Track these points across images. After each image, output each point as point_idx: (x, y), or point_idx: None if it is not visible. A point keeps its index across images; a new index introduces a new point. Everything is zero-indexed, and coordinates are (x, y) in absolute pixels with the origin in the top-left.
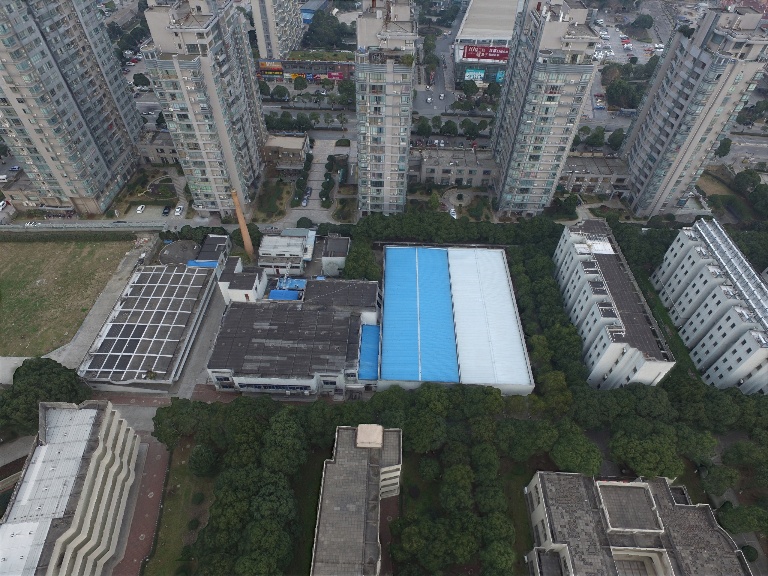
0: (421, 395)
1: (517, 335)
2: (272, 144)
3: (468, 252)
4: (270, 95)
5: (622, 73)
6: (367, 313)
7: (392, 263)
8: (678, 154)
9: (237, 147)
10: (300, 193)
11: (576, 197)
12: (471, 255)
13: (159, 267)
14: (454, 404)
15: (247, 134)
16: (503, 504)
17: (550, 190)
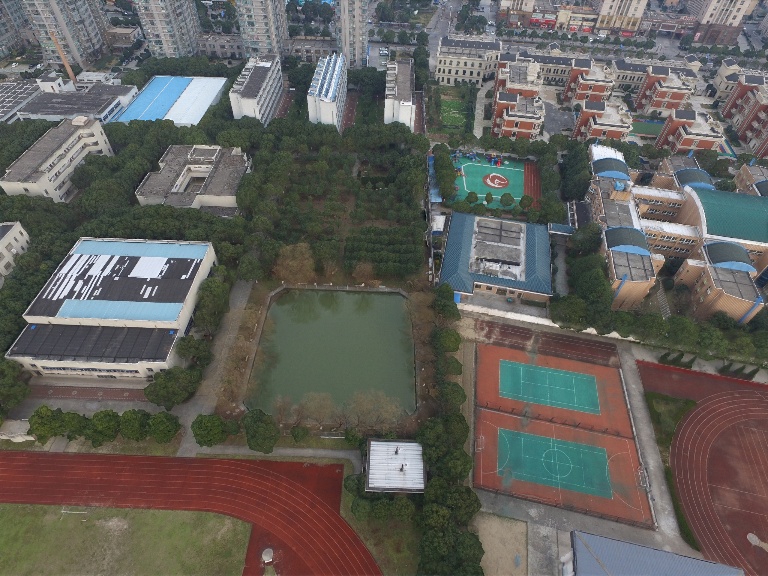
0: (129, 122)
1: (206, 109)
2: (112, 31)
3: (205, 79)
4: (132, 11)
5: (400, 3)
6: (121, 97)
7: (155, 83)
8: (342, 23)
9: (74, 22)
10: (121, 57)
11: (294, 57)
12: (206, 80)
13: (12, 84)
14: (147, 127)
15: (83, 15)
16: (146, 155)
17: (273, 50)
